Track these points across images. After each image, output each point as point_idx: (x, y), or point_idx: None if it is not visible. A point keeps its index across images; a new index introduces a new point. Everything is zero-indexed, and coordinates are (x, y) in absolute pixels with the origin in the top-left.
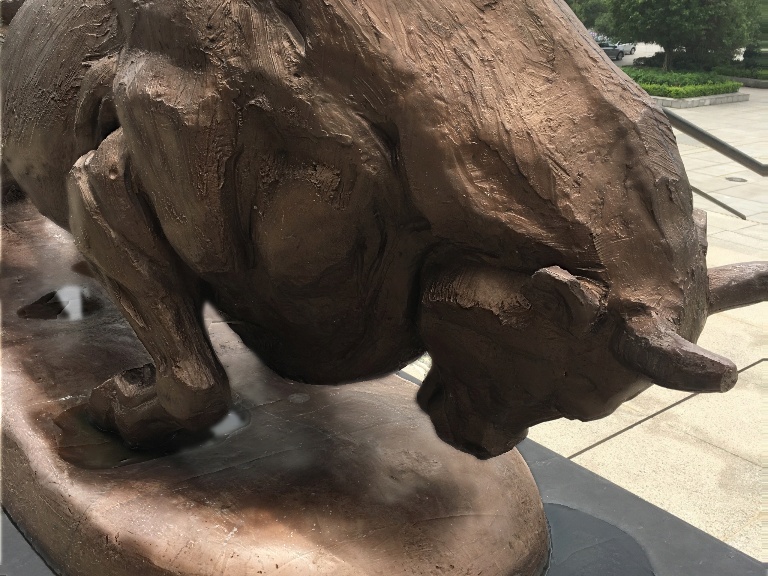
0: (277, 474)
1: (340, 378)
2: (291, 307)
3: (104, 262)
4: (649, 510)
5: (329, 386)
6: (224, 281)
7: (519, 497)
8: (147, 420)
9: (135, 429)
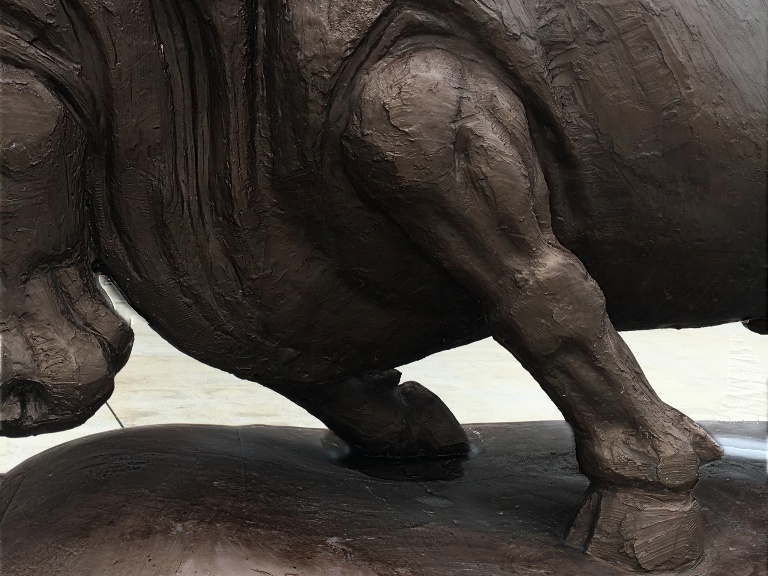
0: None
1: None
2: None
3: None
4: None
5: None
6: None
7: (14, 571)
8: None
9: None
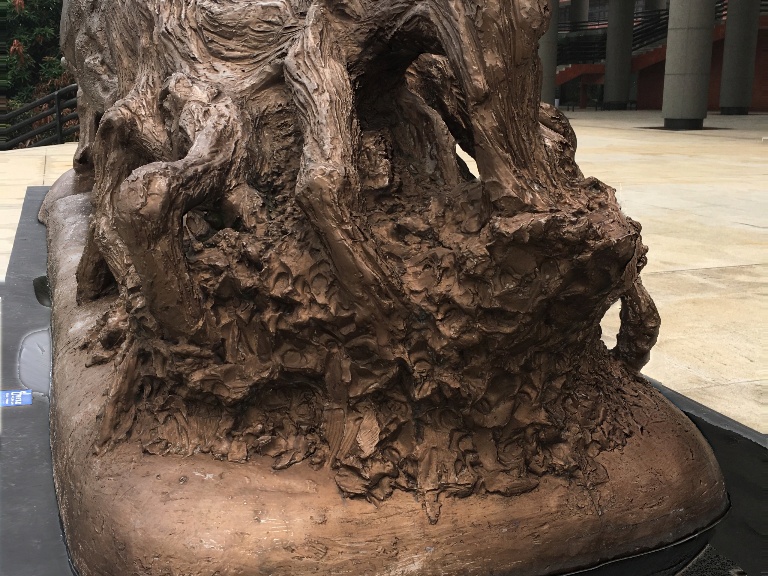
0: None
1: None
2: None
3: None
4: (32, 193)
5: None
6: None
7: None
8: None
9: None
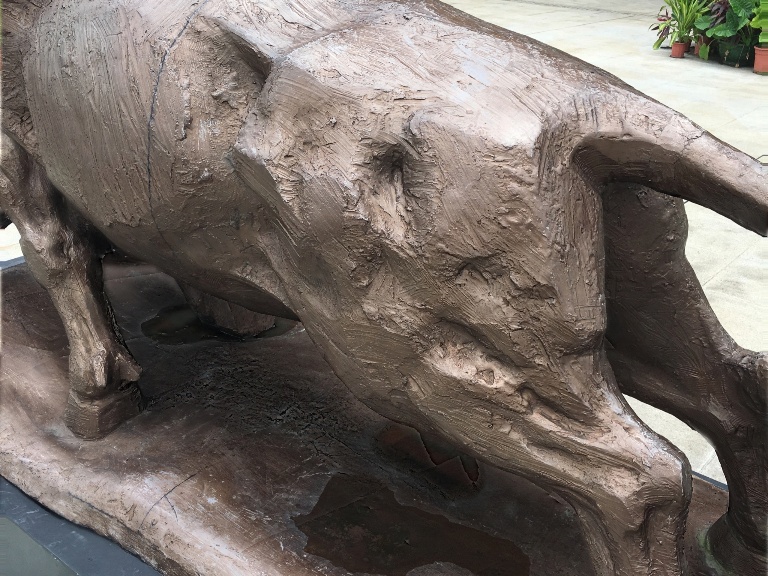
0: None
1: None
2: None
3: None
4: None
5: None
6: None
7: None
8: None
9: None
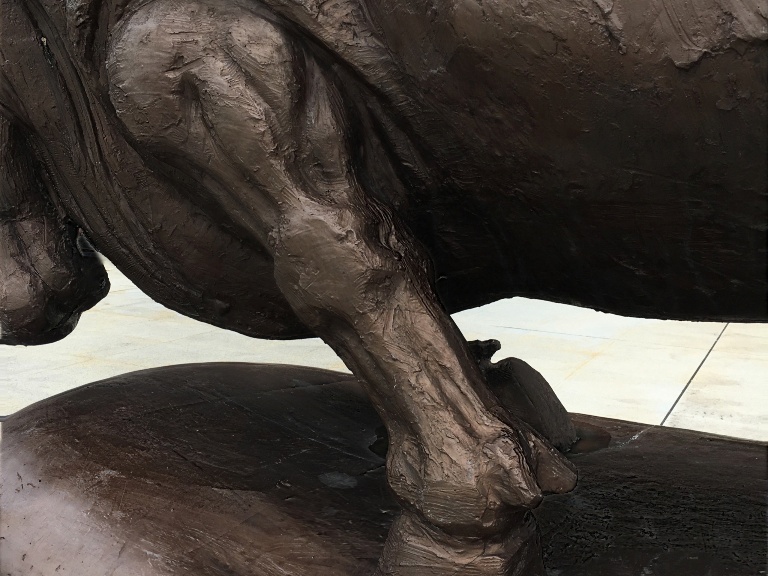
0: (256, 371)
1: None
2: None
3: None
4: None
5: (310, 506)
6: None
7: None
8: None
9: None
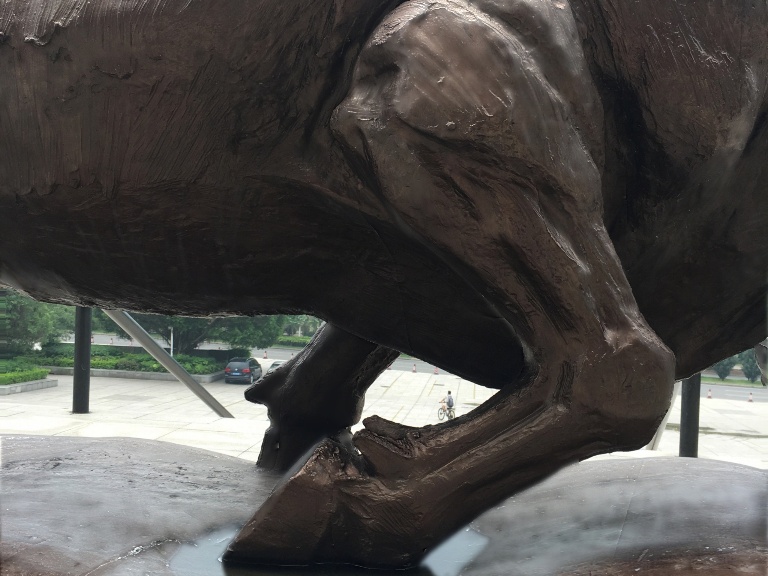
0: (707, 506)
1: (725, 352)
2: (762, 220)
3: (539, 147)
4: None
5: None
6: (713, 174)
7: None
8: (479, 482)
9: (436, 515)
